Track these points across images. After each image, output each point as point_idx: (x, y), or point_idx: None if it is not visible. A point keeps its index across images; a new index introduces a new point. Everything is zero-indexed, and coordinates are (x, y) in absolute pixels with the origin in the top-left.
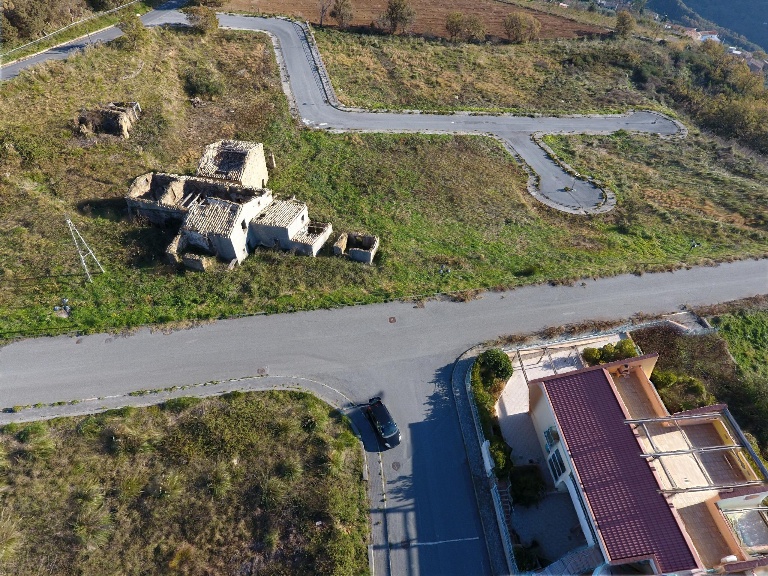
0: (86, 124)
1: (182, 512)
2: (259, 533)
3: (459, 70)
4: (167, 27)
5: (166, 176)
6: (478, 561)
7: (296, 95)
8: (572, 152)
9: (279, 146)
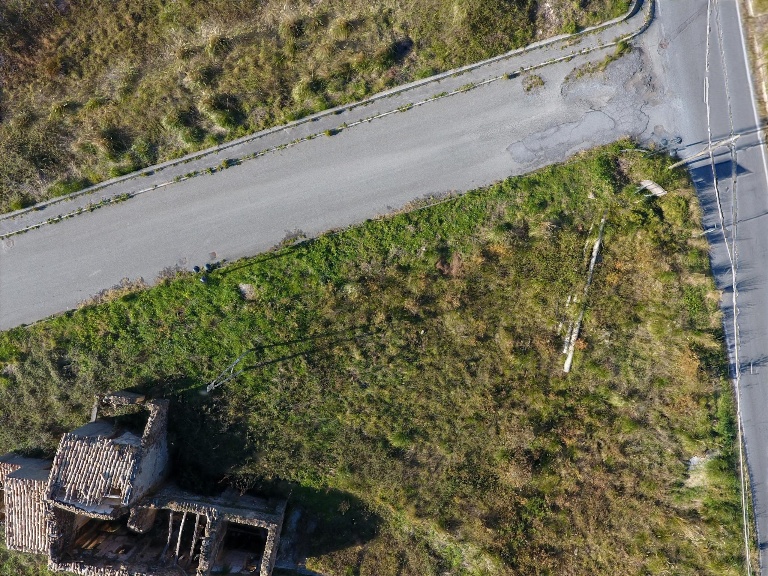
0: None
1: (61, 100)
2: None
3: None
4: None
5: None
6: None
7: None
8: None
9: None
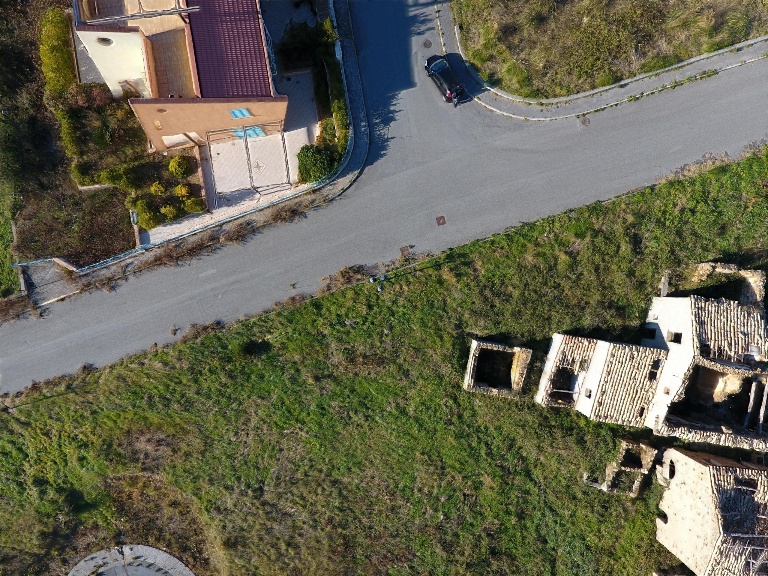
0: None
1: None
2: None
3: None
4: None
5: None
6: None
7: None
8: None
9: None
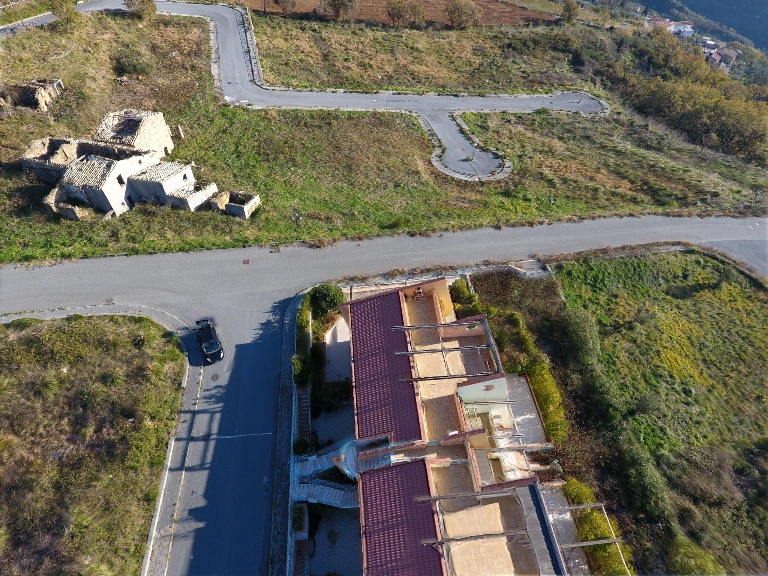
0: (4, 98)
1: (12, 411)
2: (78, 428)
3: (394, 53)
4: (104, 12)
5: (61, 140)
6: (267, 451)
7: (223, 75)
8: (486, 127)
9: (194, 120)
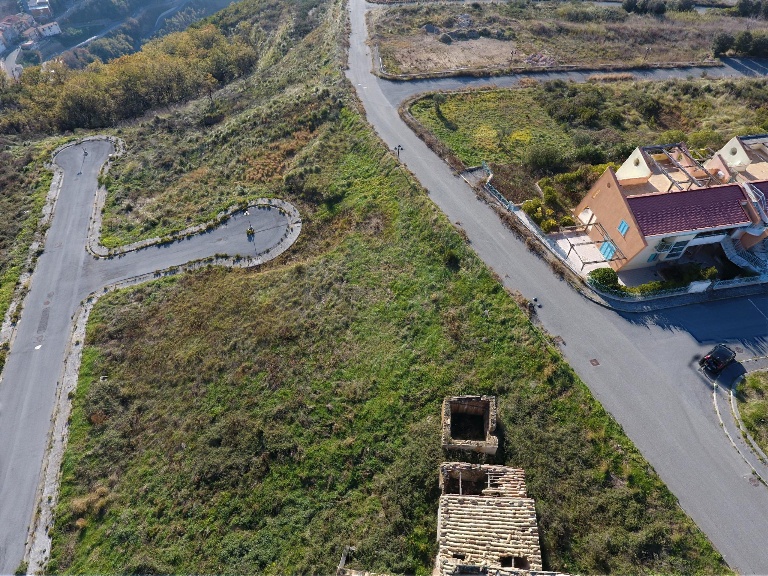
0: None
1: None
2: None
3: None
4: None
5: None
6: (763, 300)
7: None
8: (153, 223)
9: None
